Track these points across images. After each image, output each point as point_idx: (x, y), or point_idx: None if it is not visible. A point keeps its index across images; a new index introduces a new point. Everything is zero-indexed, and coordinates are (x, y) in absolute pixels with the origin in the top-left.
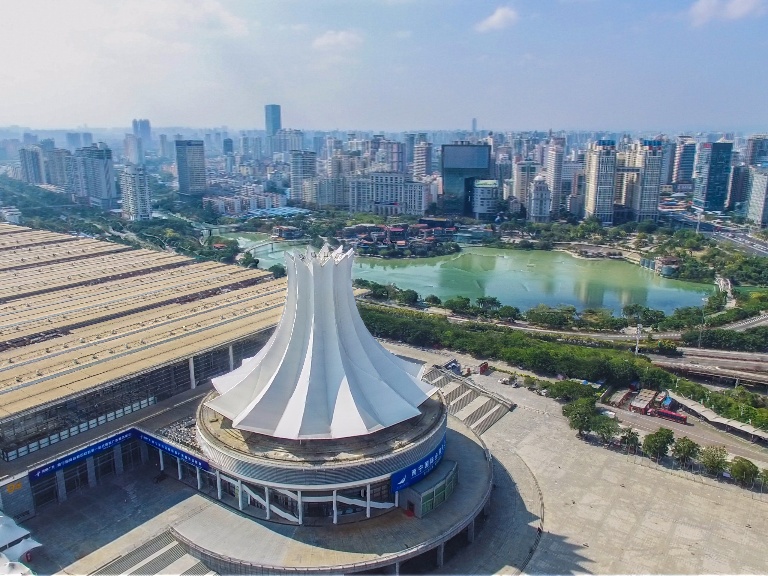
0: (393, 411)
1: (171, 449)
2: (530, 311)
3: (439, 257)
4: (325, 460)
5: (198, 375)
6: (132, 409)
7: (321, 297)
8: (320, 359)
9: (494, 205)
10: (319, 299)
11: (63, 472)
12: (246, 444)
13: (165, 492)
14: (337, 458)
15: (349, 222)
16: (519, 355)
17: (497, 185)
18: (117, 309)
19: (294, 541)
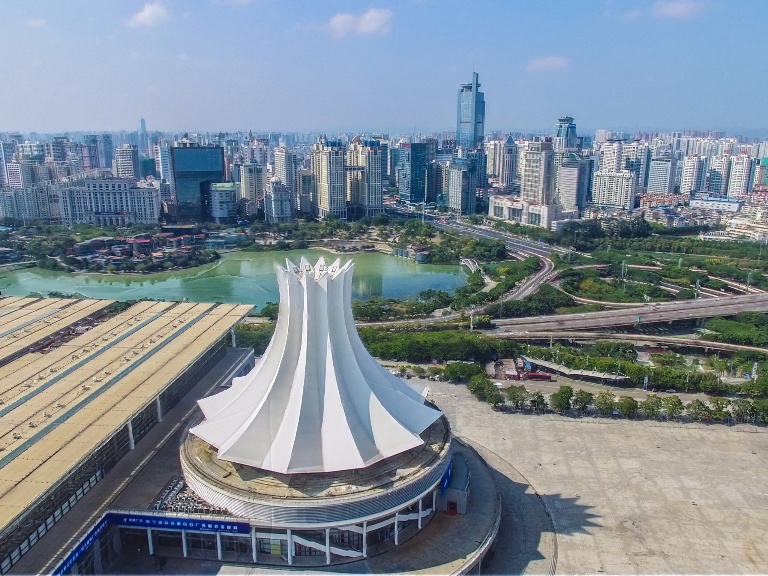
0: (417, 417)
1: (183, 522)
2: None
3: (202, 266)
4: (392, 481)
5: (134, 432)
6: (83, 492)
7: (331, 313)
8: (340, 379)
9: (233, 208)
10: (329, 316)
11: None
12: (294, 489)
13: None
14: (401, 476)
15: (76, 237)
16: (391, 348)
17: (234, 188)
18: None
19: (377, 575)
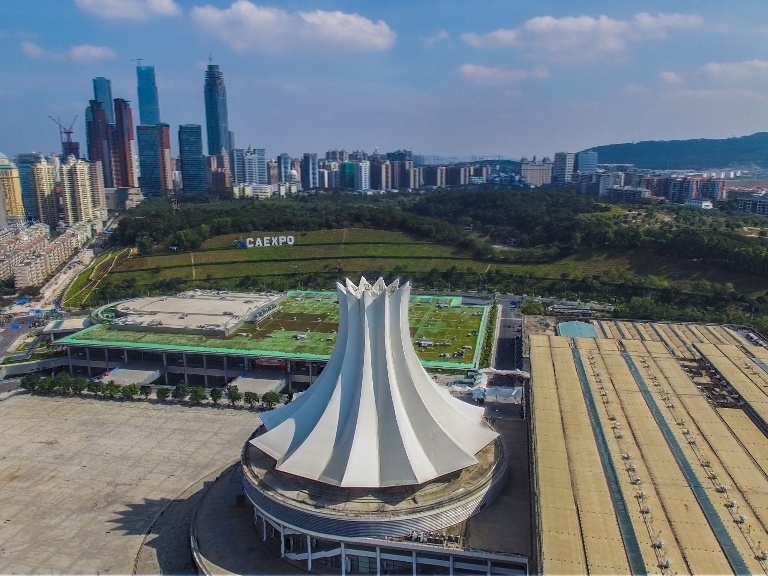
0: None
1: None
2: None
3: None
4: None
5: None
6: None
7: None
8: None
9: None
10: None
11: None
12: None
13: None
14: None
15: None
16: None
17: None
18: None
19: None
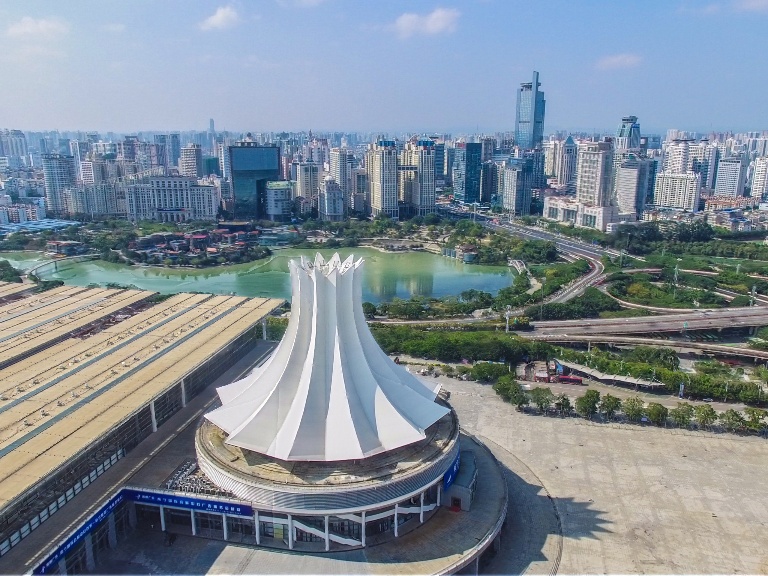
0: (424, 413)
1: (190, 502)
2: (384, 305)
3: (254, 262)
4: (391, 473)
5: (157, 415)
6: (103, 468)
7: (340, 308)
8: (347, 372)
9: (288, 206)
10: (338, 310)
11: (64, 560)
12: (295, 476)
13: (189, 553)
14: (401, 469)
15: (138, 232)
16: (422, 346)
17: (289, 186)
18: (4, 354)
19: (373, 564)
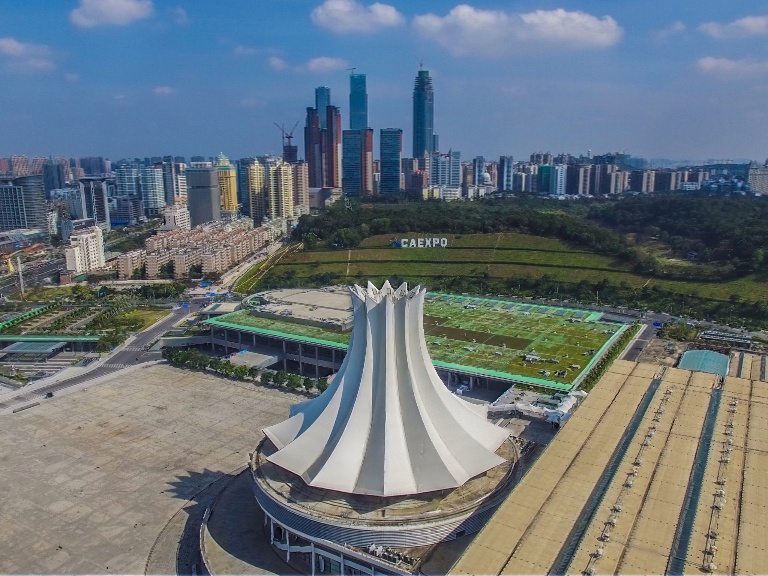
0: None
1: None
2: None
3: None
4: None
5: None
6: None
7: None
8: None
9: None
10: None
11: None
12: None
13: None
14: None
15: None
16: None
17: None
18: None
19: None
